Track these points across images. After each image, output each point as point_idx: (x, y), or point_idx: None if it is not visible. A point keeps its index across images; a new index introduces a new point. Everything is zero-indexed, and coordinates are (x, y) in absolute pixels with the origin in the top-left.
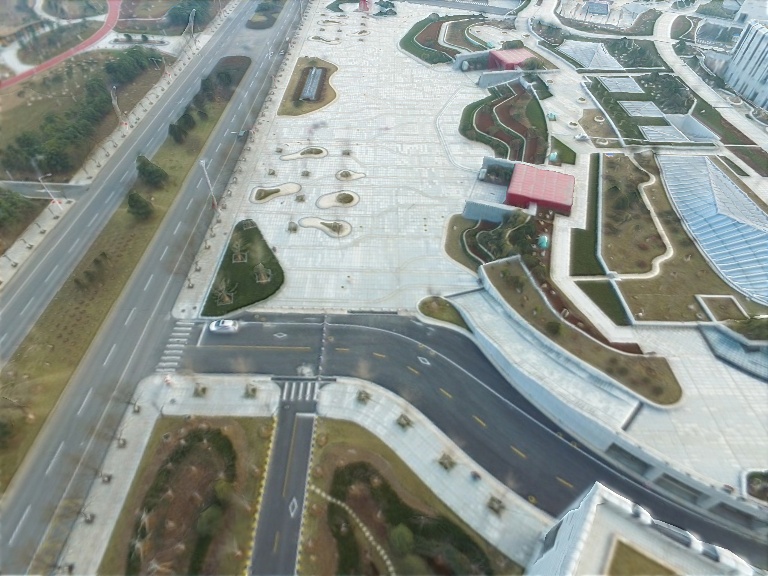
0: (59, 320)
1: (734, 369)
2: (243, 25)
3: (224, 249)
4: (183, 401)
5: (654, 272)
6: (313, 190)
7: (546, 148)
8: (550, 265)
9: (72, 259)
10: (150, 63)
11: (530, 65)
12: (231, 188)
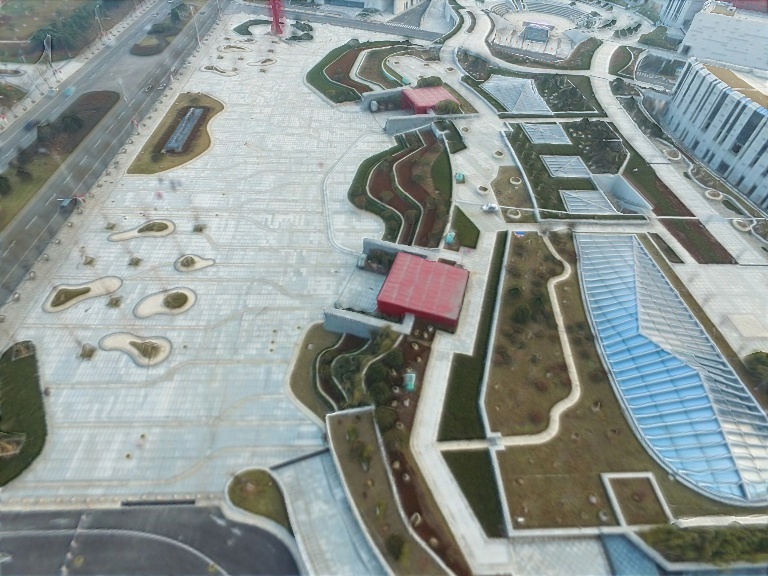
0: None
1: None
2: (127, 50)
3: None
4: None
5: (551, 431)
6: (137, 288)
7: (445, 223)
8: (413, 422)
9: None
10: None
11: (444, 109)
12: (22, 288)
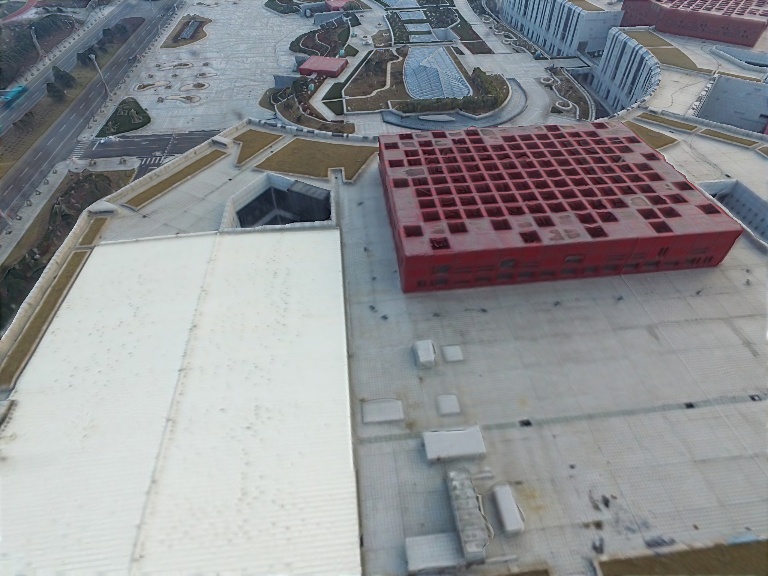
0: (5, 144)
1: (390, 125)
2: None
3: (113, 111)
4: (83, 168)
5: (371, 95)
6: (178, 83)
7: None
8: (311, 97)
9: (11, 122)
10: (63, 23)
11: (349, 7)
12: (121, 85)
